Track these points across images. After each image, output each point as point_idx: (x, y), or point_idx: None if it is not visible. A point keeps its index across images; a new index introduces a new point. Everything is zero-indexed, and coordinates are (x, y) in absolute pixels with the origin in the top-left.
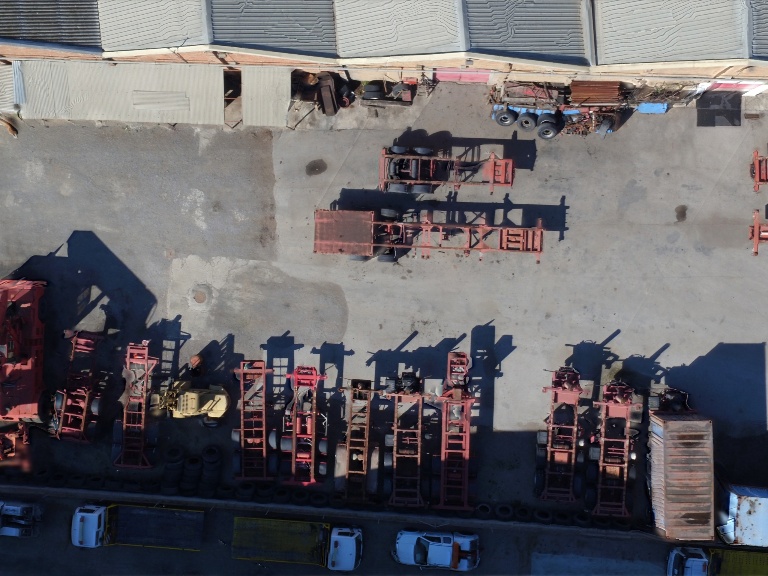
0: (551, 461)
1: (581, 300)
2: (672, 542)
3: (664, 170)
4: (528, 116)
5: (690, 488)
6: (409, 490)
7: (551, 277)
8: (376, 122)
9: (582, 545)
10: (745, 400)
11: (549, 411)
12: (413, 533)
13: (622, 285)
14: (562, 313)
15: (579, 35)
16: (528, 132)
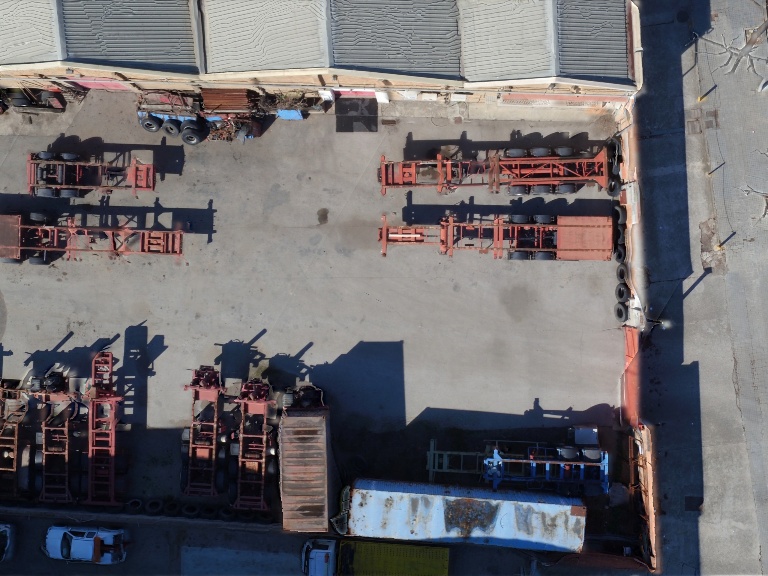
0: (193, 457)
1: (229, 301)
2: (307, 534)
3: (306, 174)
4: (170, 122)
5: (305, 482)
6: (58, 486)
7: (200, 278)
8: (30, 128)
9: (229, 538)
10: (385, 396)
11: (200, 409)
12: (61, 528)
13: (268, 286)
14: (211, 313)
15: (190, 44)
16: (175, 138)
